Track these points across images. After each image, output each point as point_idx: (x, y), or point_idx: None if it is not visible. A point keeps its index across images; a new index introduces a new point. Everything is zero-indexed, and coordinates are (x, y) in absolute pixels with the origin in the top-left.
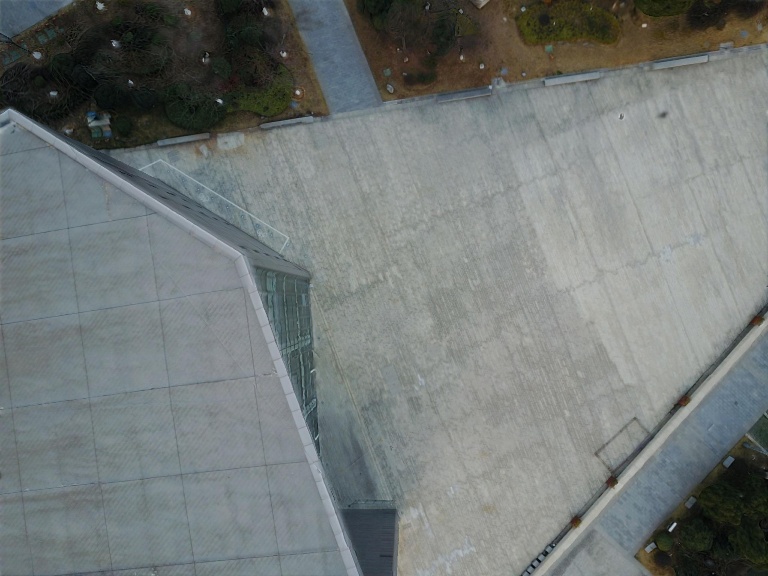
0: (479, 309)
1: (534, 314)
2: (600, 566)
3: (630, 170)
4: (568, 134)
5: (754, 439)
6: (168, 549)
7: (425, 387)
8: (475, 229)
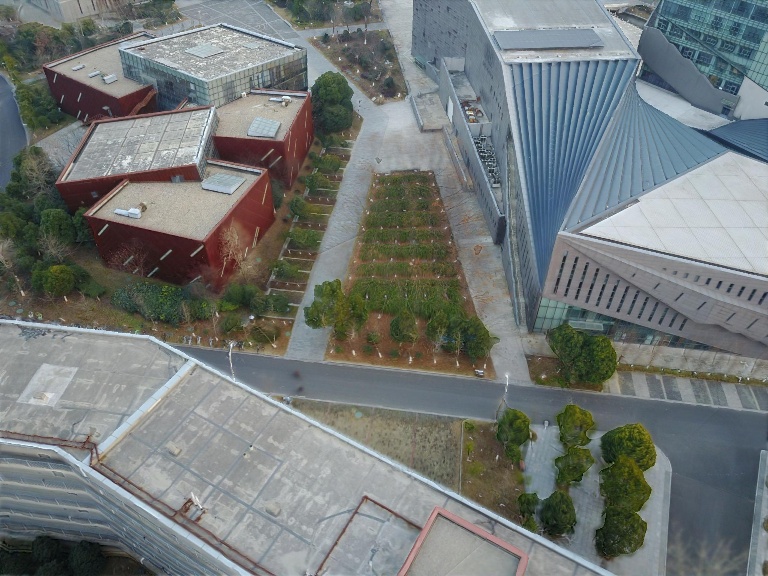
0: None
1: None
2: None
3: None
4: (397, 1)
5: None
6: None
7: None
8: None
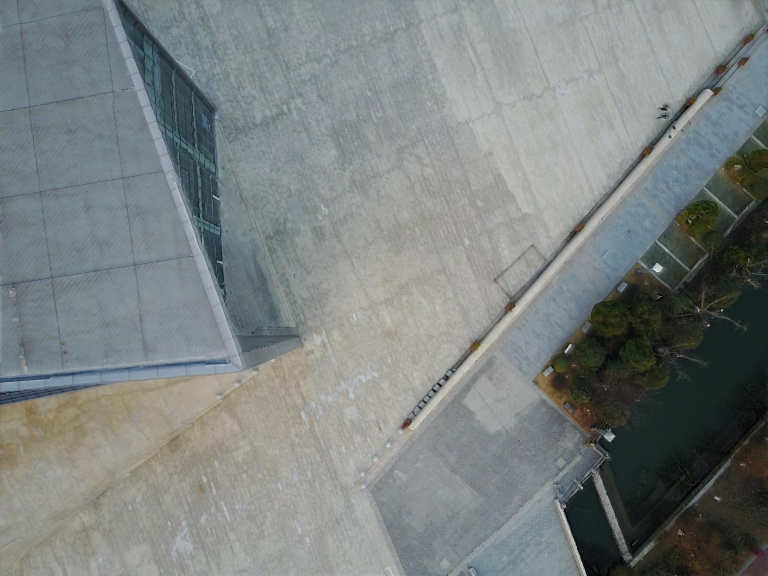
0: (381, 140)
1: (435, 145)
2: (500, 391)
3: (527, 8)
4: None
5: (647, 266)
6: (26, 265)
7: (328, 216)
8: (378, 63)
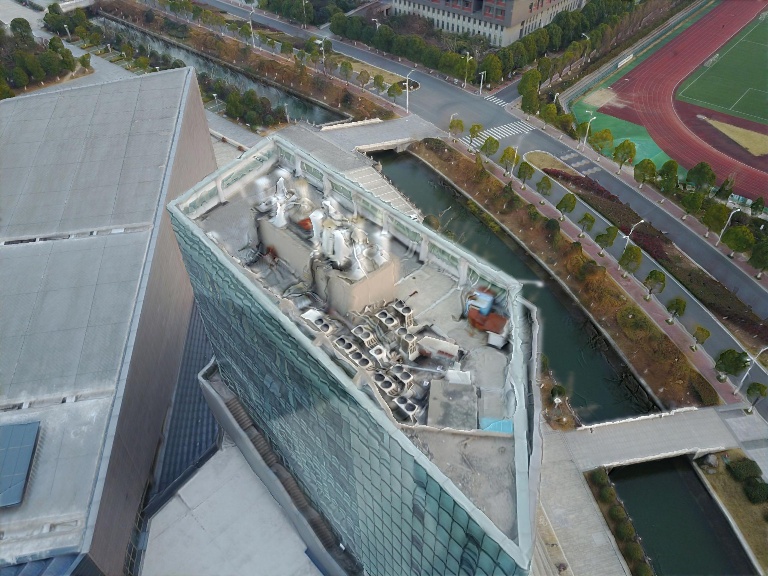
0: None
1: None
2: None
3: None
4: None
5: None
6: None
7: None
8: None
